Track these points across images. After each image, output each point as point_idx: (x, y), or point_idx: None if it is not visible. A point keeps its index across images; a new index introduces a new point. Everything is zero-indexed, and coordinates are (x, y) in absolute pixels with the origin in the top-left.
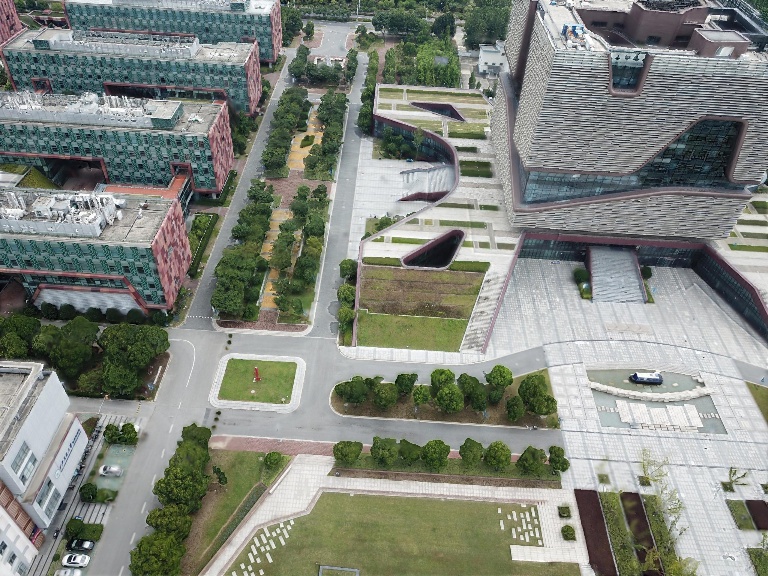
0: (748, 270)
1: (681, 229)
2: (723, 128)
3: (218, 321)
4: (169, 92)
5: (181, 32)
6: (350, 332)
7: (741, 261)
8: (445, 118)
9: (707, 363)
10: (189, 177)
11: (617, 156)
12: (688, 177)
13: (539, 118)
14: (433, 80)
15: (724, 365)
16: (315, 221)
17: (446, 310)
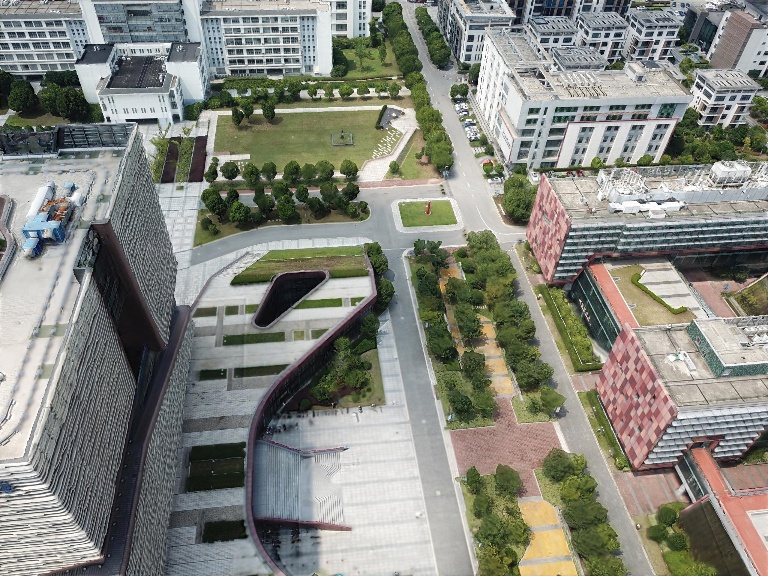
0: None
1: None
2: None
3: None
4: None
5: None
6: None
7: None
8: None
9: None
10: None
11: None
12: None
13: None
14: None
15: None
16: (442, 333)
17: None
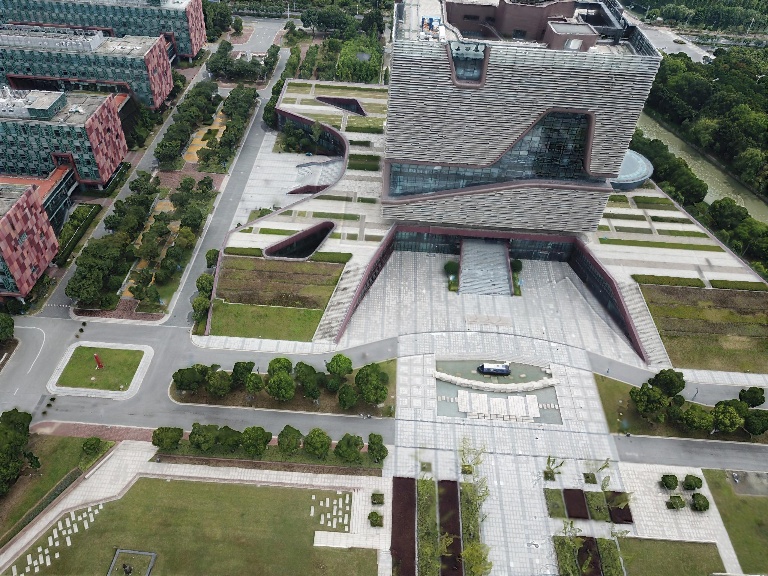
0: (612, 263)
1: (549, 222)
2: (574, 120)
3: (75, 309)
4: (73, 85)
5: (99, 26)
6: (205, 321)
7: (607, 254)
8: (347, 112)
9: (559, 355)
10: (71, 168)
11: (473, 148)
12: (548, 170)
13: (389, 109)
14: (349, 76)
15: (576, 357)
16: (190, 212)
17: (303, 300)
